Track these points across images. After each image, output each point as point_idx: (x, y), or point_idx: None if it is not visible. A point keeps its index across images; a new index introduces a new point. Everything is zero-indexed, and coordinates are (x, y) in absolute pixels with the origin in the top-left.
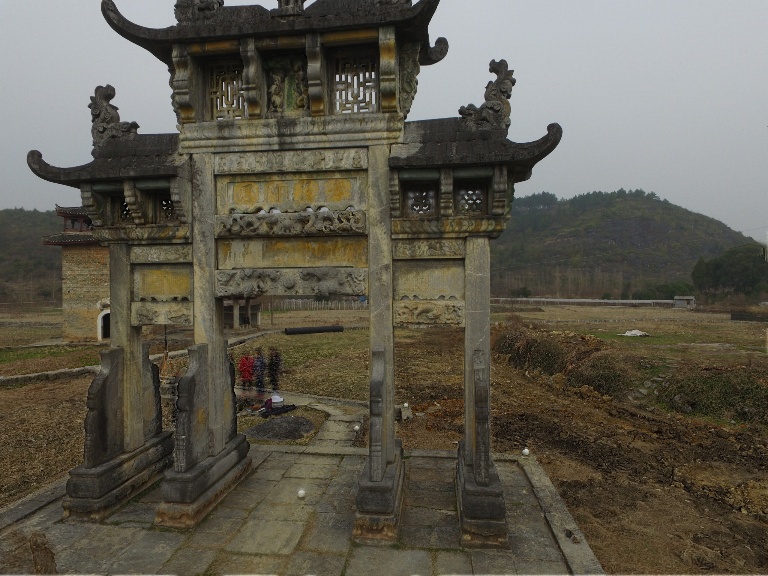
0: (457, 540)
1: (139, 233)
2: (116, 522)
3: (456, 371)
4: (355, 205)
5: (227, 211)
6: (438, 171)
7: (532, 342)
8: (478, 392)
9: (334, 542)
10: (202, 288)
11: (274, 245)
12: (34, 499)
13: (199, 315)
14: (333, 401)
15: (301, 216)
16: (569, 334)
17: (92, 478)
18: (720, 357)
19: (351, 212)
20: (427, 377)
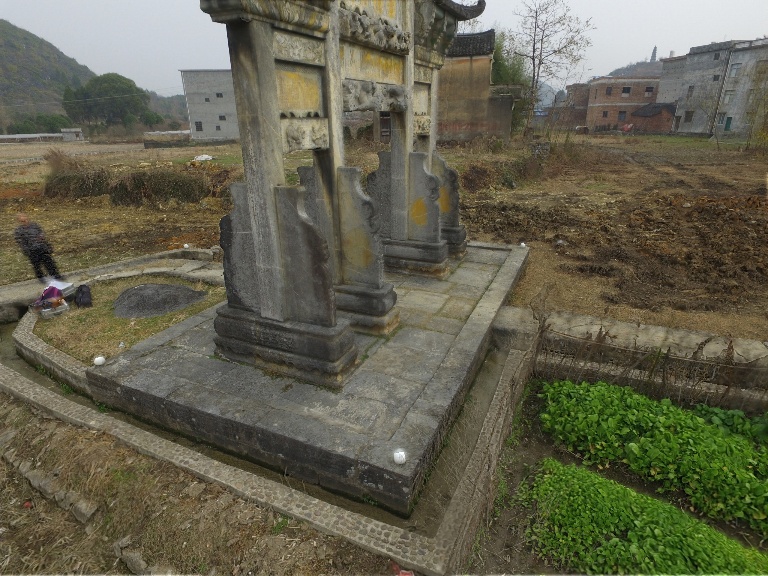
0: (455, 260)
1: (290, 11)
2: (365, 356)
3: (82, 222)
4: (398, 25)
5: (339, 3)
6: (444, 13)
7: (139, 176)
8: (456, 173)
9: (441, 285)
10: (336, 101)
11: (366, 56)
12: (253, 421)
13: (336, 134)
14: (104, 269)
15: (393, 30)
16: (169, 163)
17: (347, 329)
18: (310, 164)
19: (408, 34)
20: (72, 233)
